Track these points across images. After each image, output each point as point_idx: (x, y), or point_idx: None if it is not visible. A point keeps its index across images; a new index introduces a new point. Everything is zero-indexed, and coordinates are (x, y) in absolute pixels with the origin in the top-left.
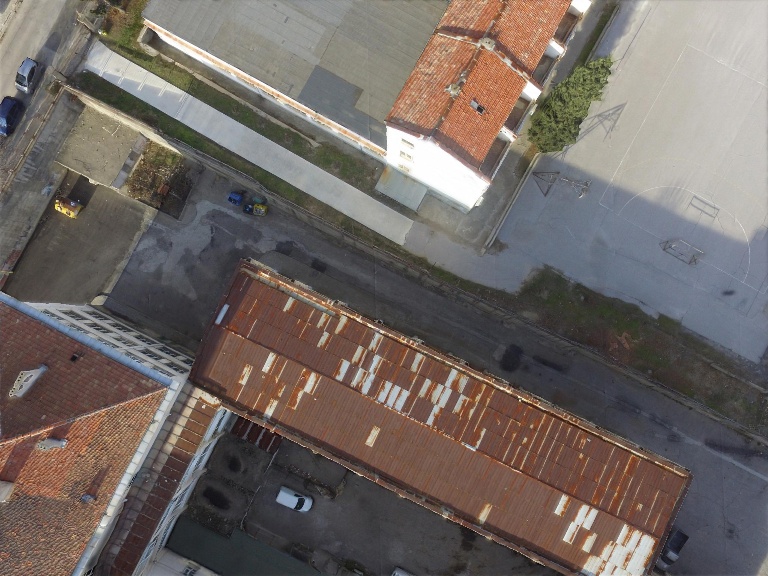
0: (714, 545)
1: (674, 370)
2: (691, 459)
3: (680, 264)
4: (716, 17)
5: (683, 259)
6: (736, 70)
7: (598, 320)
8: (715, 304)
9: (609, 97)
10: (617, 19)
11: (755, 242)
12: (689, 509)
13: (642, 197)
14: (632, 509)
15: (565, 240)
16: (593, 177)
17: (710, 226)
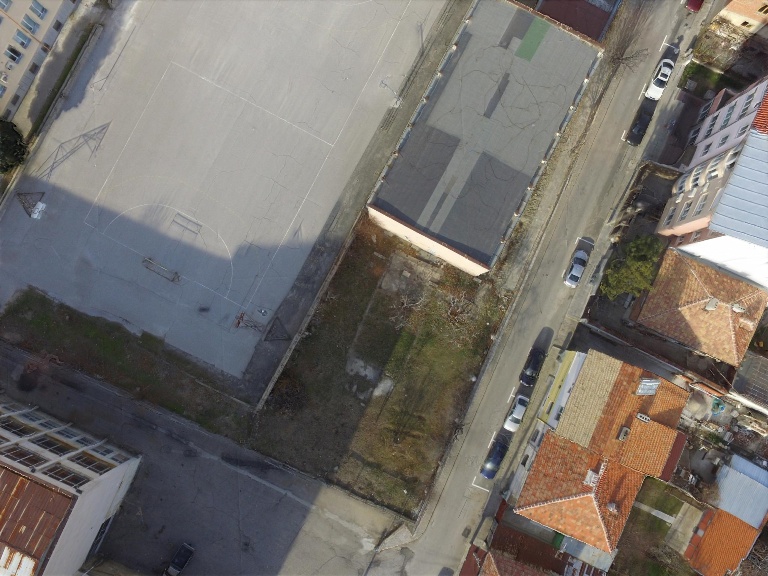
0: (228, 558)
1: (164, 387)
2: (207, 473)
3: (163, 281)
4: (200, 34)
5: (166, 276)
6: (220, 86)
7: (83, 339)
8: (198, 320)
9: (94, 116)
10: (102, 38)
11: (238, 257)
12: (204, 523)
13: (127, 215)
14: (14, 531)
15: (50, 260)
16: (79, 197)
17: (193, 243)
